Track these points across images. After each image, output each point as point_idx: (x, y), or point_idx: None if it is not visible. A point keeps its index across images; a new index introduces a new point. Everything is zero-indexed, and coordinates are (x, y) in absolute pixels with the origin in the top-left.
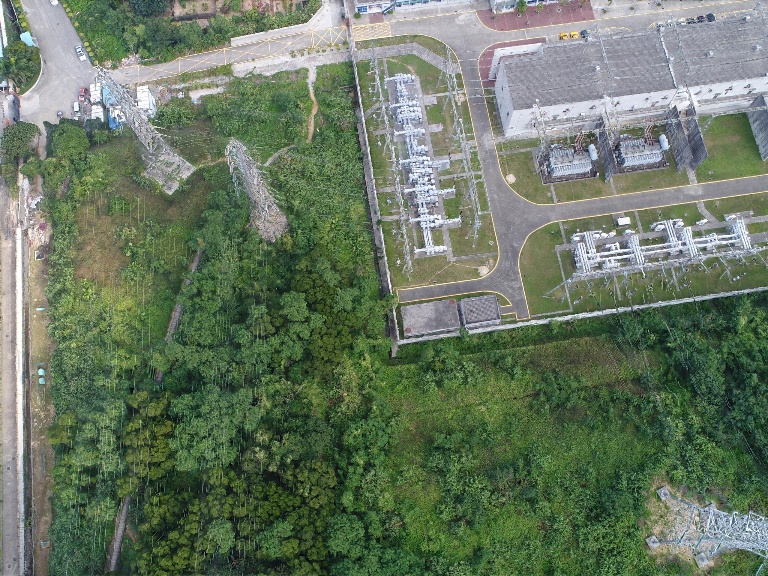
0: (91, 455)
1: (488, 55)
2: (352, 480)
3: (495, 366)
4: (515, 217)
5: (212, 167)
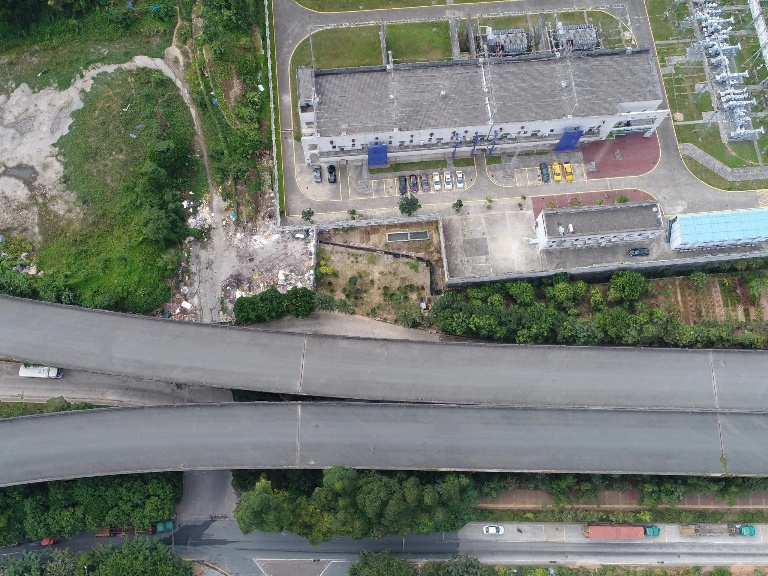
0: None
1: (651, 162)
2: None
3: None
4: (624, 1)
5: None
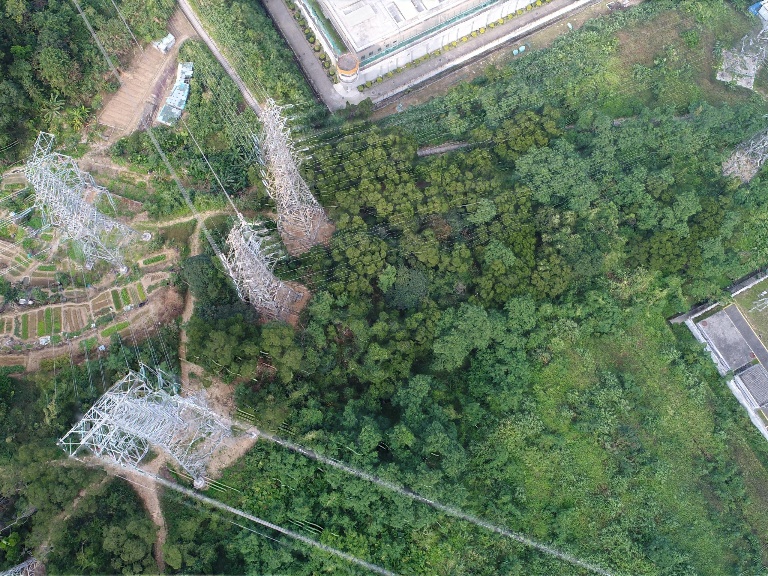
0: (492, 99)
1: None
2: (562, 309)
3: (714, 414)
4: None
5: (762, 100)
